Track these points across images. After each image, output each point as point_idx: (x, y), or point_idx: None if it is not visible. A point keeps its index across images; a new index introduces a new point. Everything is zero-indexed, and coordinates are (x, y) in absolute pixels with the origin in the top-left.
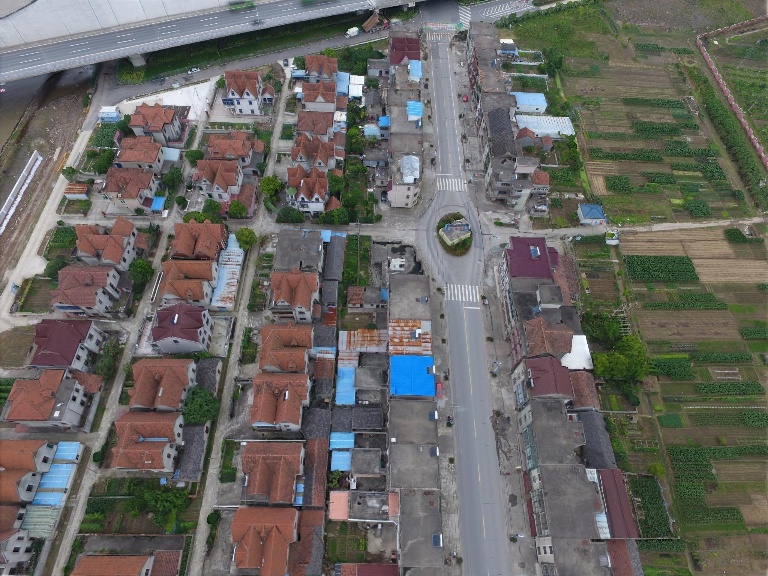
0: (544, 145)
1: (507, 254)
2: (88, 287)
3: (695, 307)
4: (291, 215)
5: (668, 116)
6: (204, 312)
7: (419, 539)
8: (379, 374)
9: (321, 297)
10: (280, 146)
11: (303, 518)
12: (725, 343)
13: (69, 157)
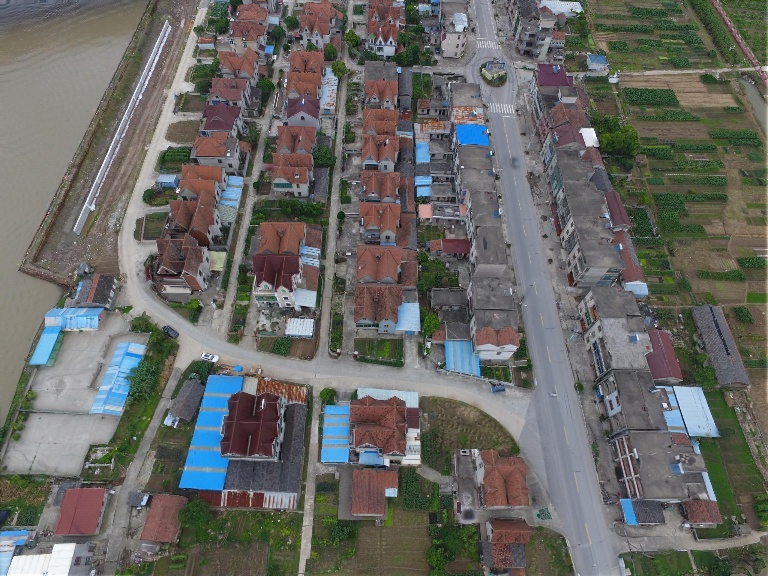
0: (560, 20)
1: (536, 72)
2: (234, 88)
3: (676, 119)
4: (371, 56)
5: (658, 5)
6: None
7: (484, 213)
8: (446, 146)
9: (399, 104)
10: (354, 19)
11: (402, 215)
12: (697, 140)
13: (194, 24)
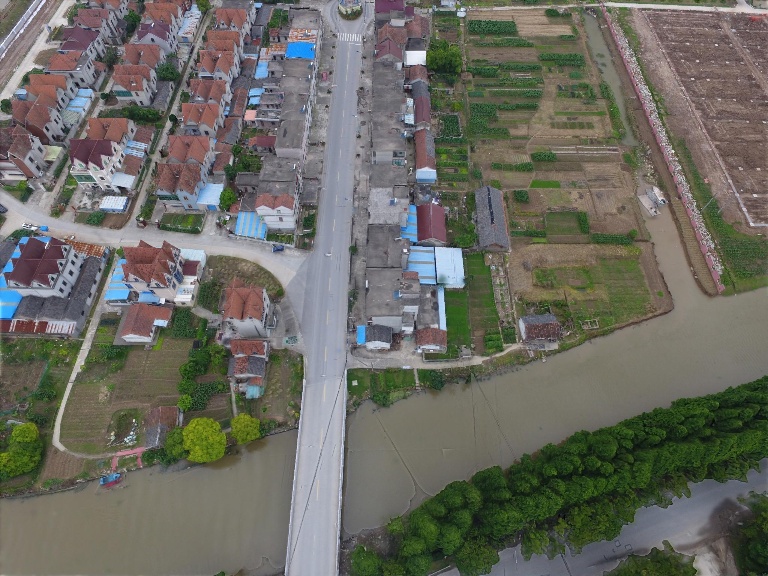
0: None
1: None
2: None
3: (510, 45)
4: None
5: None
6: (171, 27)
7: (292, 110)
8: None
9: (251, 32)
10: None
11: None
12: (526, 62)
13: None
